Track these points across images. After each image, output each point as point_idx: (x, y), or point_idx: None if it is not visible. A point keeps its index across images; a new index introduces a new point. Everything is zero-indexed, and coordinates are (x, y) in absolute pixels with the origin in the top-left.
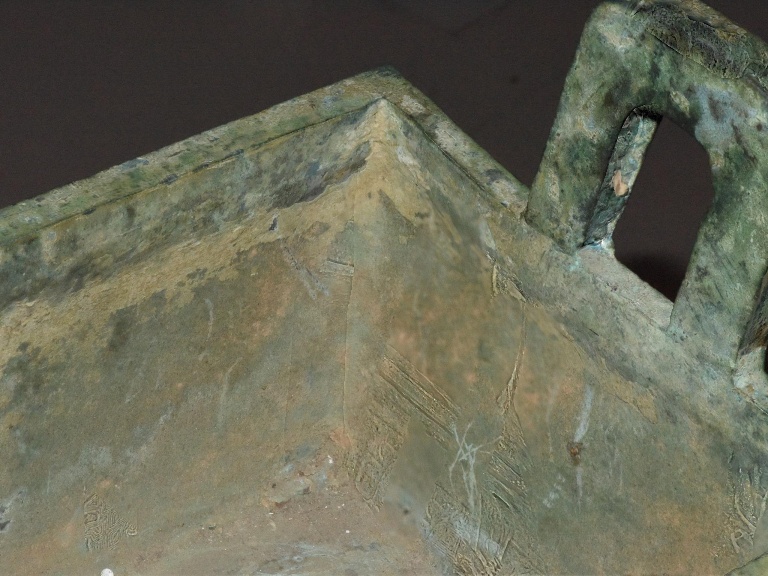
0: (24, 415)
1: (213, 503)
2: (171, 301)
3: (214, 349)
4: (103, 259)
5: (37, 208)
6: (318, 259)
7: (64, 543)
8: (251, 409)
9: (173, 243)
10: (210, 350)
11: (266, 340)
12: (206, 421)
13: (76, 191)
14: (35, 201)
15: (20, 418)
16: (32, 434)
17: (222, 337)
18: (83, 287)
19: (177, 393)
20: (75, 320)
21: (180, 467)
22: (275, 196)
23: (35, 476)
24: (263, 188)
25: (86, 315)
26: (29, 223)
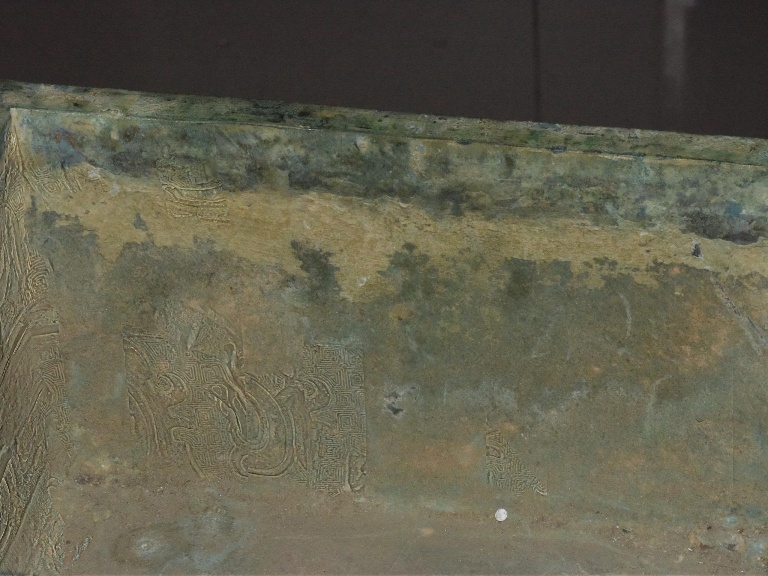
0: (414, 314)
1: (639, 510)
2: (579, 277)
3: (636, 351)
4: (479, 195)
5: (431, 123)
6: (763, 314)
7: (463, 462)
8: (687, 436)
9: (564, 215)
10: (631, 350)
11: (701, 371)
12: (630, 421)
13: (475, 124)
14: (437, 118)
15: (410, 315)
16: (425, 337)
17: (645, 343)
18: (464, 215)
19: (594, 376)
20: (464, 246)
21: (601, 454)
22: (687, 218)
23: (429, 380)
24: (668, 203)
25: (476, 246)
26: (409, 129)
